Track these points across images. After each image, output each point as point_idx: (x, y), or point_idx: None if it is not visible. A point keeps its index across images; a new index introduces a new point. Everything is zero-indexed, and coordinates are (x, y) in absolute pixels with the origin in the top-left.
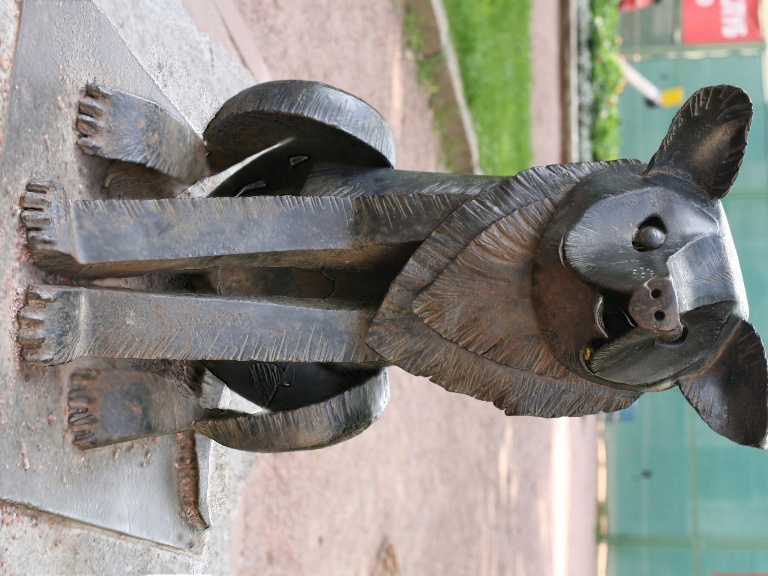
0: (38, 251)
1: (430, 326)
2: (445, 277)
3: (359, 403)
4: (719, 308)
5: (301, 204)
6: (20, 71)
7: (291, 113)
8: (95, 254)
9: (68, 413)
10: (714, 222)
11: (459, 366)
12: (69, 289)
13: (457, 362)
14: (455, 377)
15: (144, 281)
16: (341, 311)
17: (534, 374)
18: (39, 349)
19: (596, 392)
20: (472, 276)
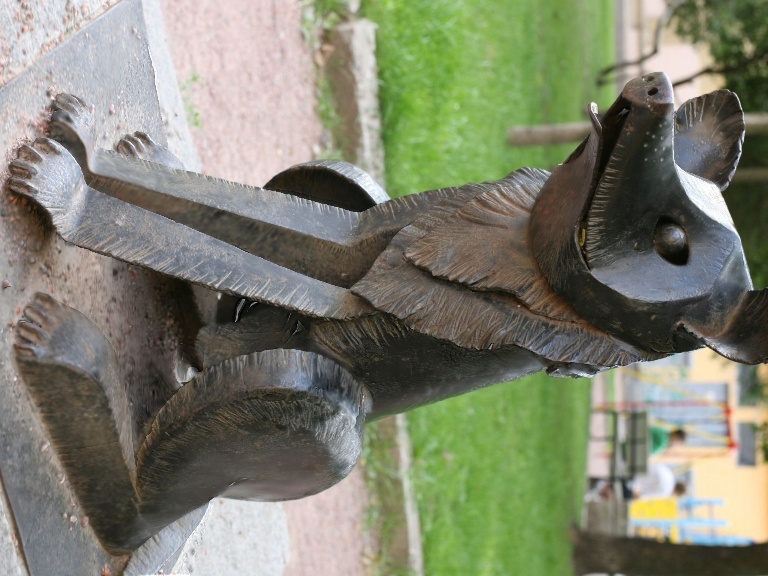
0: (58, 124)
1: (421, 264)
2: (442, 227)
3: (331, 376)
4: (720, 232)
5: (310, 205)
6: (93, 33)
7: (315, 166)
8: (105, 172)
9: (21, 318)
10: (712, 182)
11: (446, 308)
12: (74, 159)
13: (445, 304)
14: (441, 323)
15: (125, 368)
16: (330, 284)
17: (526, 311)
18: (28, 179)
19: (592, 339)
20: (470, 224)
